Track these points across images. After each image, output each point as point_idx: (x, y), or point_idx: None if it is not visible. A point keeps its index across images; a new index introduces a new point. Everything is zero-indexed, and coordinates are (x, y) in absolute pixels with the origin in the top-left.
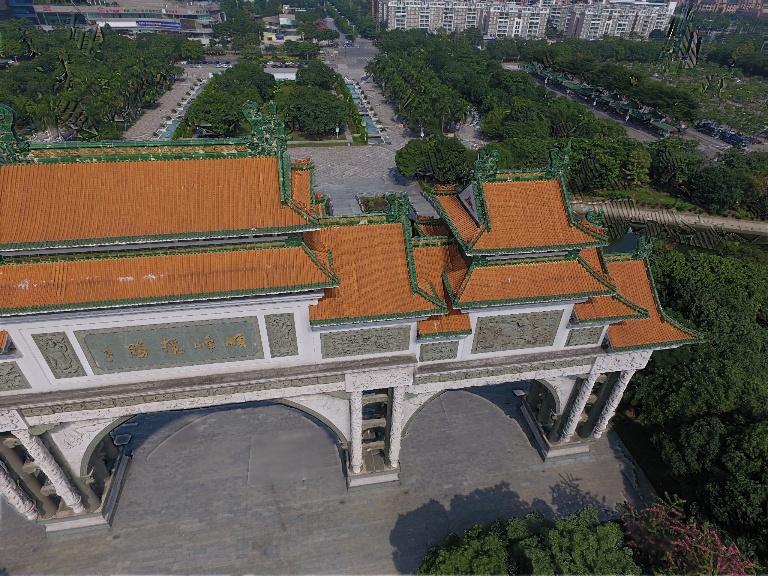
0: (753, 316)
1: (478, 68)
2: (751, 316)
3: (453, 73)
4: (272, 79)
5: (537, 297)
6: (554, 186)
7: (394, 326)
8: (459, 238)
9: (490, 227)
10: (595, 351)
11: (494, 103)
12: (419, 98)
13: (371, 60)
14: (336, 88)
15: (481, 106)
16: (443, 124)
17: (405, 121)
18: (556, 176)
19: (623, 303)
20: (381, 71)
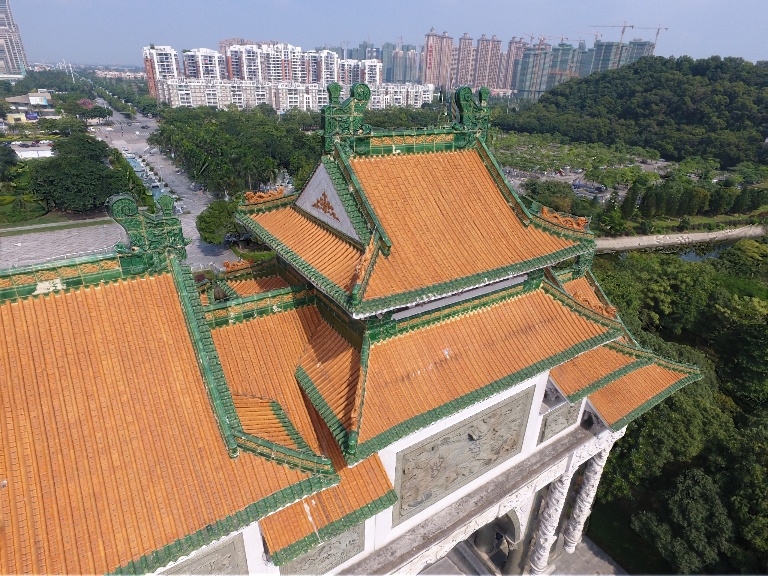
0: (639, 326)
1: (277, 134)
2: (638, 327)
3: (252, 138)
4: (12, 154)
5: (508, 377)
6: (473, 160)
7: (194, 554)
8: (322, 282)
9: (389, 243)
10: (579, 437)
11: (302, 162)
12: (216, 159)
13: (153, 131)
14: (112, 163)
15: (289, 167)
16: (250, 185)
17: (204, 186)
18: (471, 142)
19: (610, 347)
20: (167, 141)
